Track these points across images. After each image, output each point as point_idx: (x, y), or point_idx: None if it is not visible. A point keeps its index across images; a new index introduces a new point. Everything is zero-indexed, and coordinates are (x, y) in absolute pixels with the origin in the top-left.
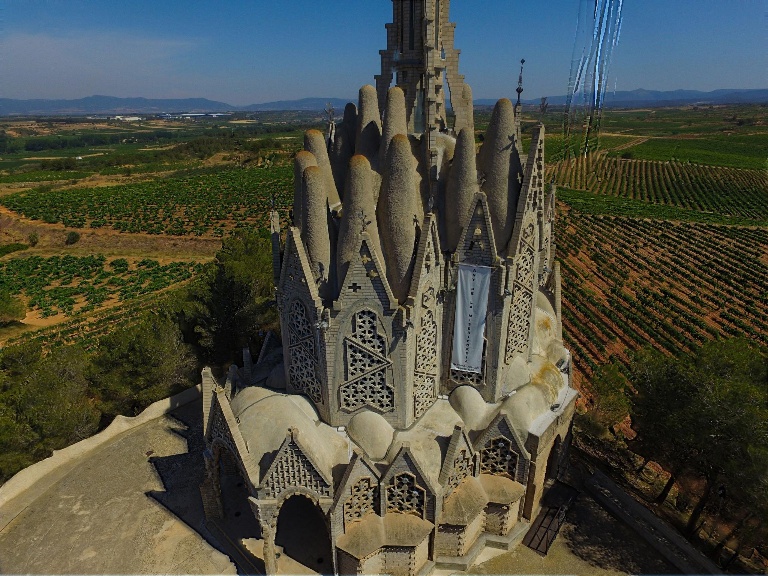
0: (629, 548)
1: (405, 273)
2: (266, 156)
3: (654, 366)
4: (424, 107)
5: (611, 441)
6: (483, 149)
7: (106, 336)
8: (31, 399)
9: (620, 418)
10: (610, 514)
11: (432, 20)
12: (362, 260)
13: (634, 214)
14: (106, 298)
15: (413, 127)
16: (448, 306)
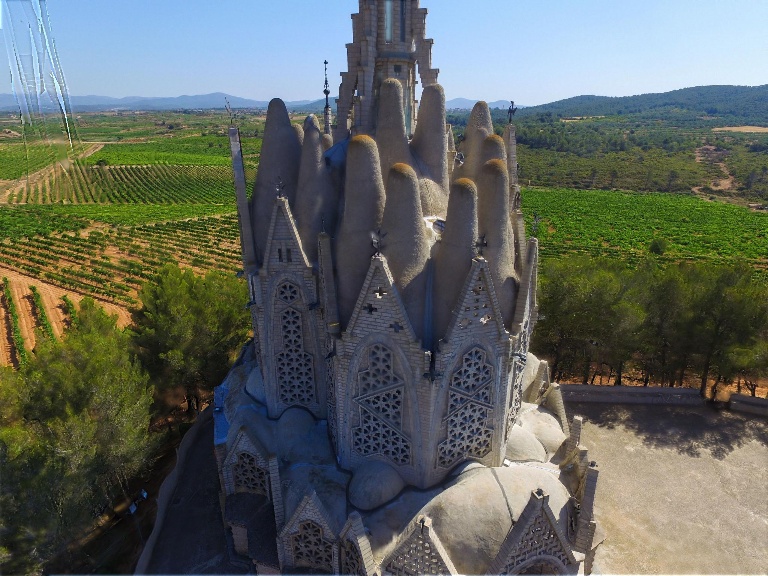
0: (568, 411)
1: None
2: None
3: None
4: (409, 107)
5: None
6: None
7: None
8: None
9: None
10: None
11: None
12: None
13: (172, 217)
14: None
15: None
16: None
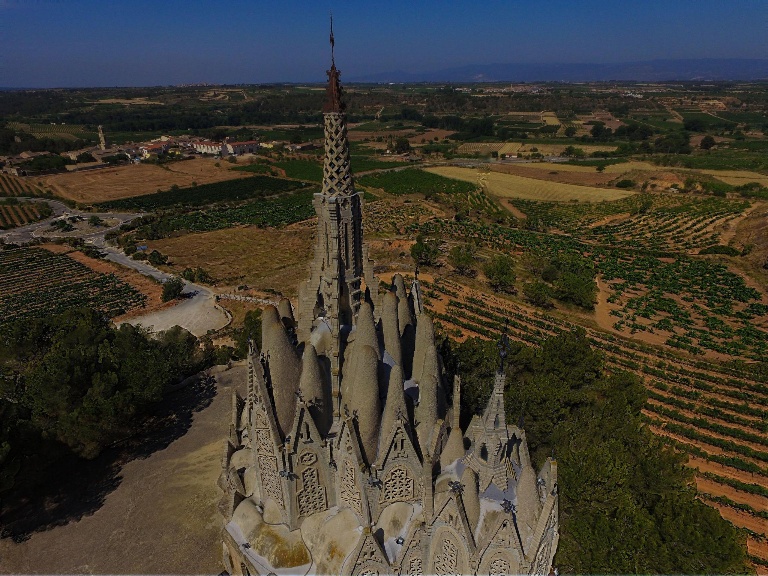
0: None
1: None
2: None
3: None
4: None
5: None
6: None
7: None
8: None
9: None
10: None
11: None
12: None
13: None
14: (668, 329)
15: None
16: None
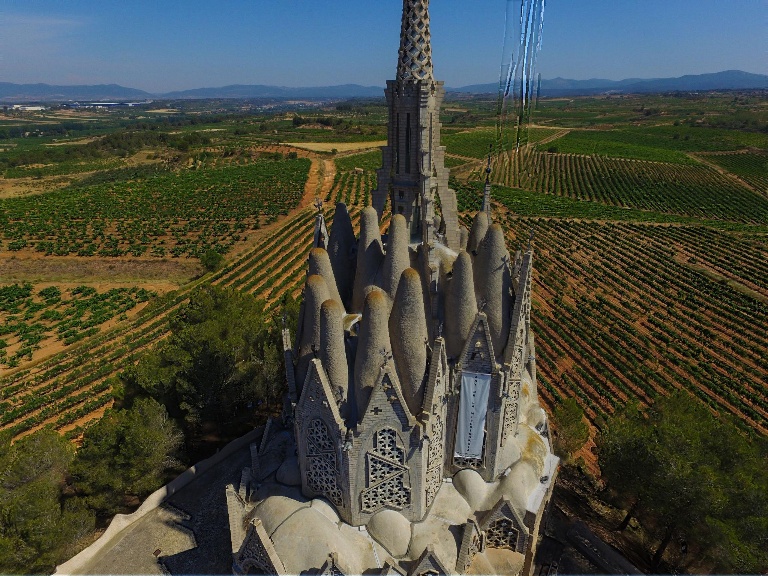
0: None
1: (418, 389)
2: (197, 157)
3: (623, 437)
4: (419, 221)
5: (573, 466)
6: (477, 266)
7: (90, 428)
8: (21, 511)
9: (580, 445)
10: (591, 562)
11: (428, 152)
12: (383, 388)
13: (565, 214)
14: (43, 337)
15: (409, 239)
16: (451, 405)
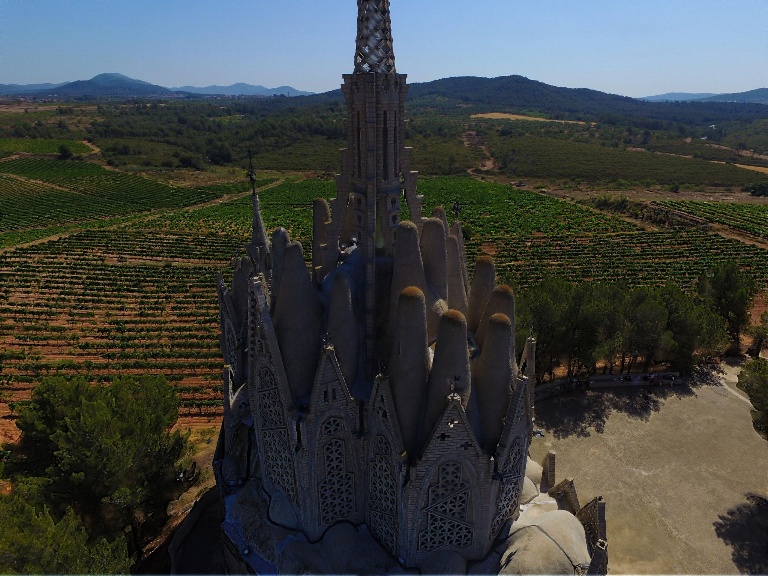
0: None
1: None
2: None
3: None
4: None
5: None
6: None
7: None
8: None
9: None
10: None
11: None
12: None
13: None
14: None
15: None
16: None
